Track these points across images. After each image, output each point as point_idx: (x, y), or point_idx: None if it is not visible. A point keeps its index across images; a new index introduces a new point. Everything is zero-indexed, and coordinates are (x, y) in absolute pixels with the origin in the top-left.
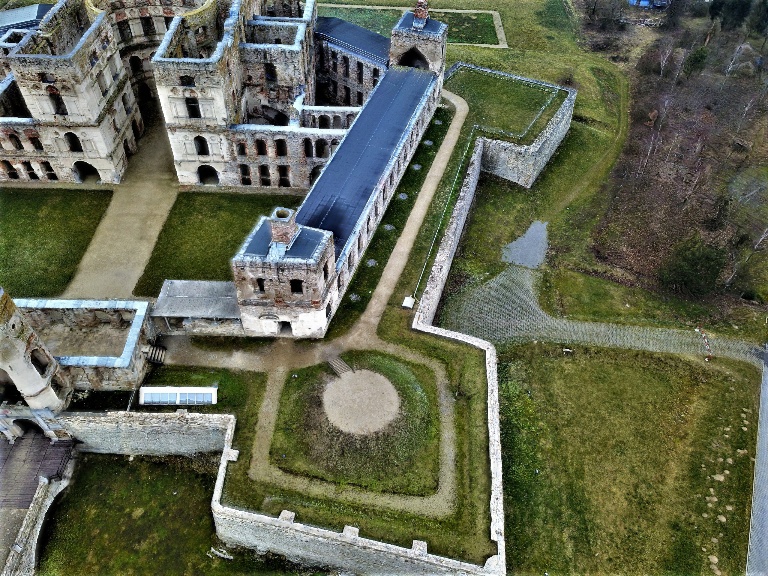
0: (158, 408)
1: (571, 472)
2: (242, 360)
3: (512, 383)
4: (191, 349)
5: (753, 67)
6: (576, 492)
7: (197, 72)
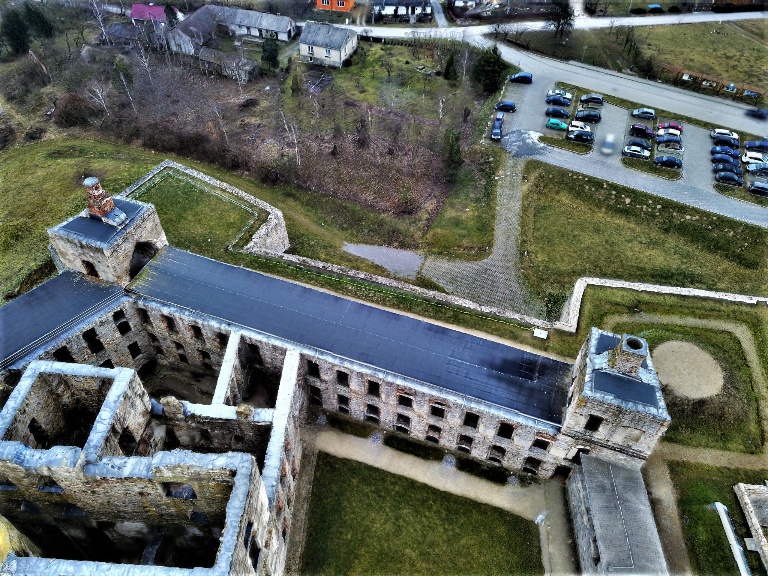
0: (756, 572)
1: (642, 273)
2: (661, 487)
3: (568, 294)
4: (662, 549)
5: (125, 57)
6: (658, 273)
7: (250, 502)
